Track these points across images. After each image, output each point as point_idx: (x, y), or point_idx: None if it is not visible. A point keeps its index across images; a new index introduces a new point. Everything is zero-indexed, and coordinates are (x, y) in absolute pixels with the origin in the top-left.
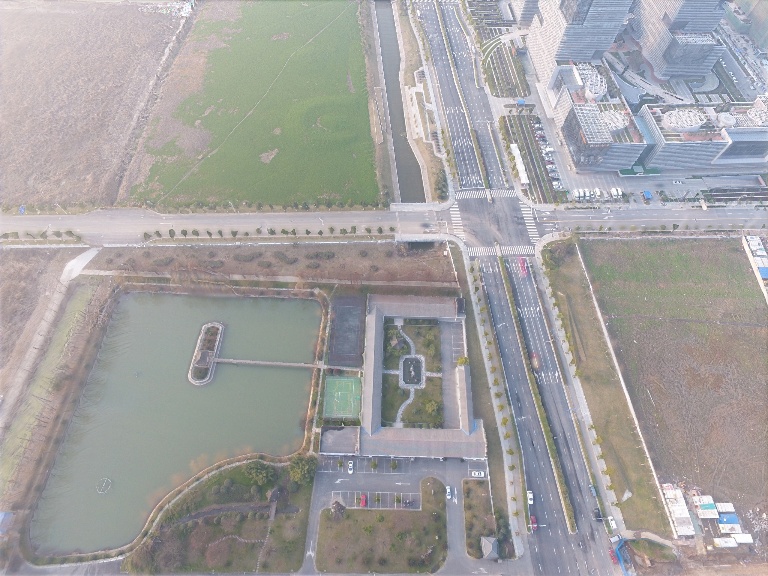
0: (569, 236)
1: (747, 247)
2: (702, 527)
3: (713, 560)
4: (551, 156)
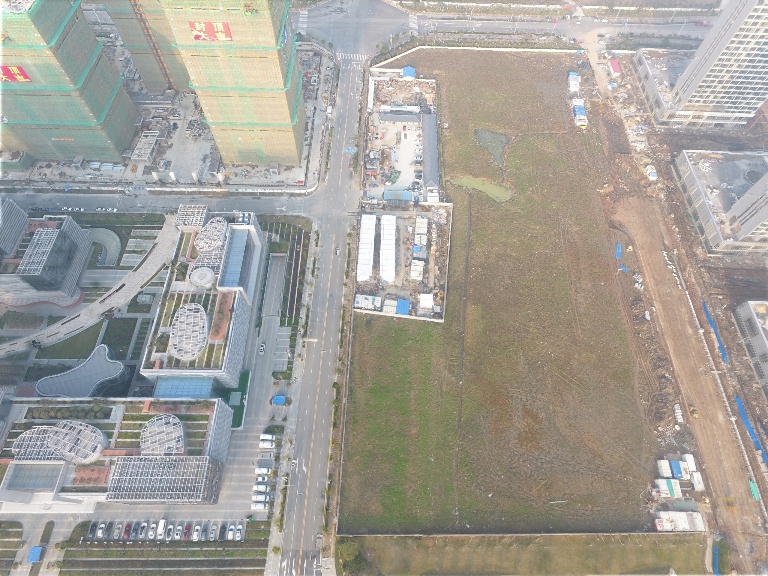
0: (330, 540)
1: (368, 312)
2: (686, 498)
3: (710, 496)
4: (173, 525)
